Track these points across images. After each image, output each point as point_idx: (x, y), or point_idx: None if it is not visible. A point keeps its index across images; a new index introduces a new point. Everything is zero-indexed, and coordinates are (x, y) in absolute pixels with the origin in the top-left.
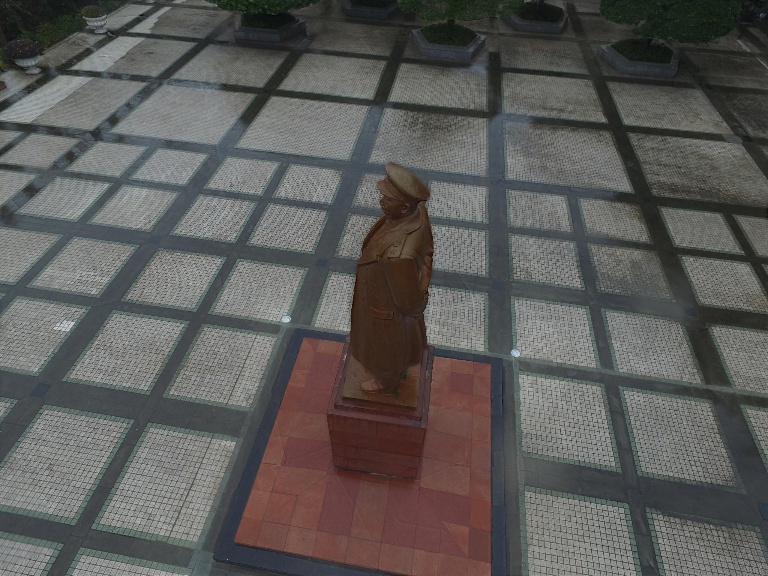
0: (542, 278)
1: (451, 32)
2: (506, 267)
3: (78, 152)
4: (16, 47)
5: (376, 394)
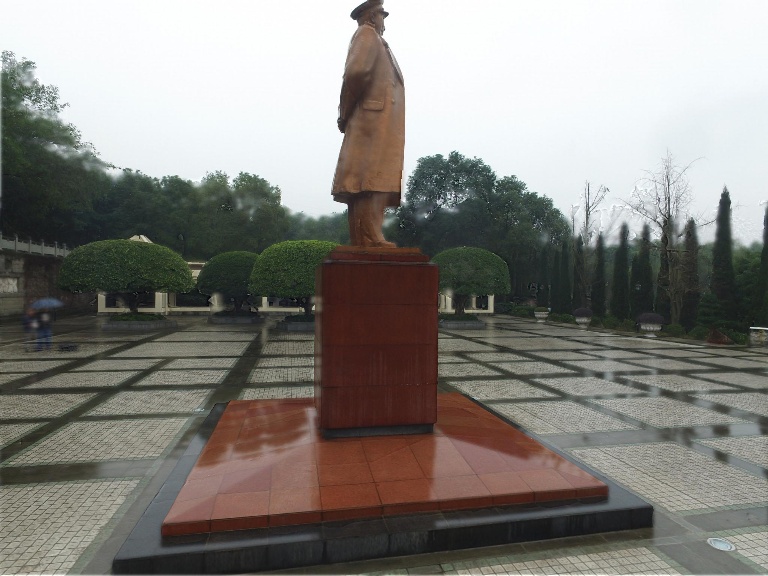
0: None
1: None
2: None
3: None
4: None
5: None
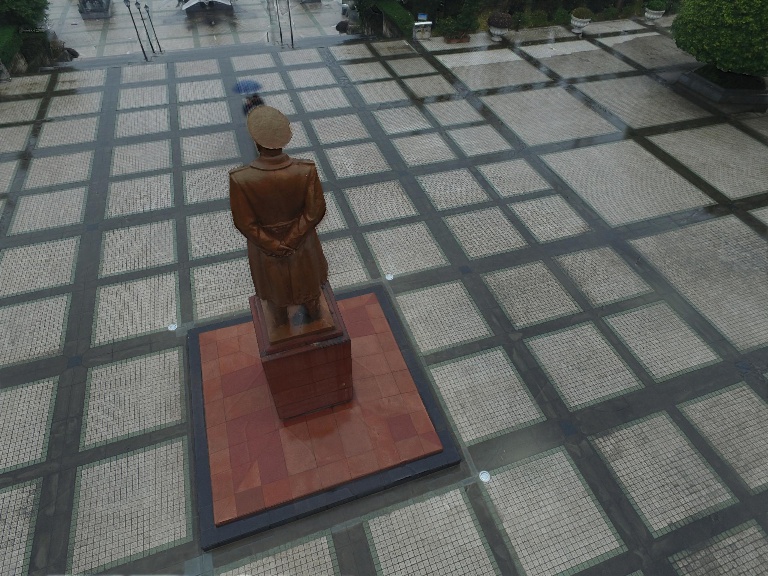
0: (625, 473)
1: None
2: (604, 426)
3: (445, 99)
4: (496, 17)
5: None
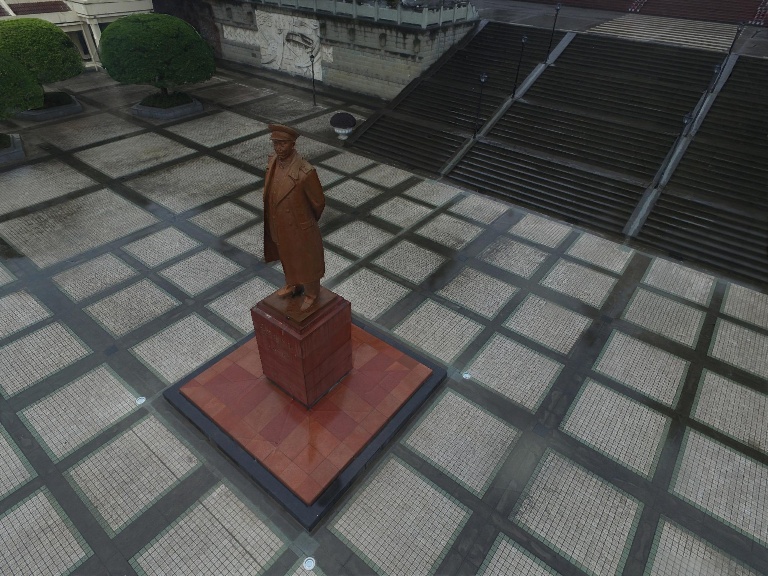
0: None
1: None
2: (248, 257)
3: None
4: None
5: (313, 307)
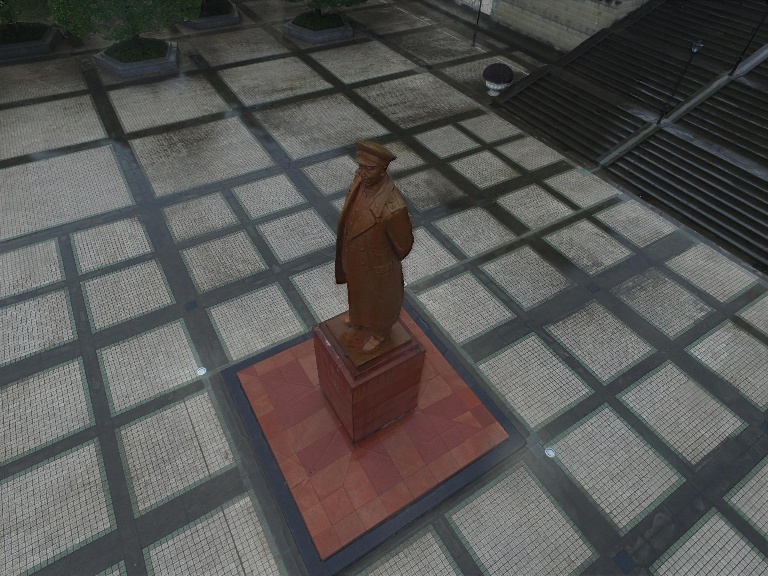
0: None
1: (141, 46)
2: None
3: None
4: None
5: (378, 349)
